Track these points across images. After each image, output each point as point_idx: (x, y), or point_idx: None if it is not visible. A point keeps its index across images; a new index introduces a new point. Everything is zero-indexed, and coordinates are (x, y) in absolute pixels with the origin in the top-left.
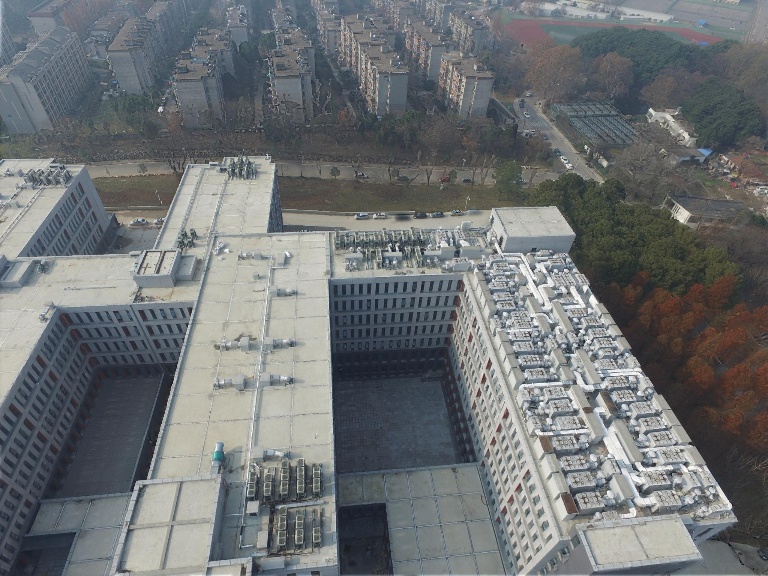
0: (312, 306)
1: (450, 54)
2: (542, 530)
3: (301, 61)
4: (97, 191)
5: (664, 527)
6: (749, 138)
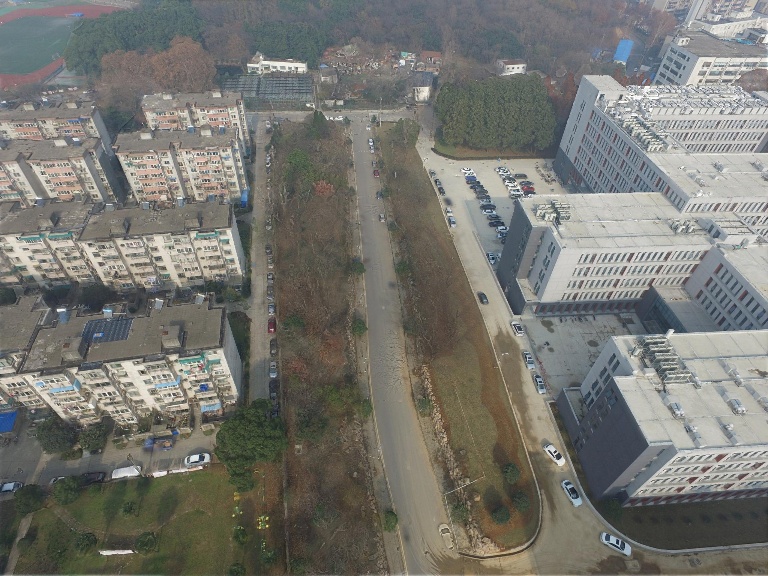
0: (719, 159)
1: (153, 105)
2: (762, 128)
3: (182, 198)
4: (499, 448)
5: (760, 94)
6: (351, 41)
